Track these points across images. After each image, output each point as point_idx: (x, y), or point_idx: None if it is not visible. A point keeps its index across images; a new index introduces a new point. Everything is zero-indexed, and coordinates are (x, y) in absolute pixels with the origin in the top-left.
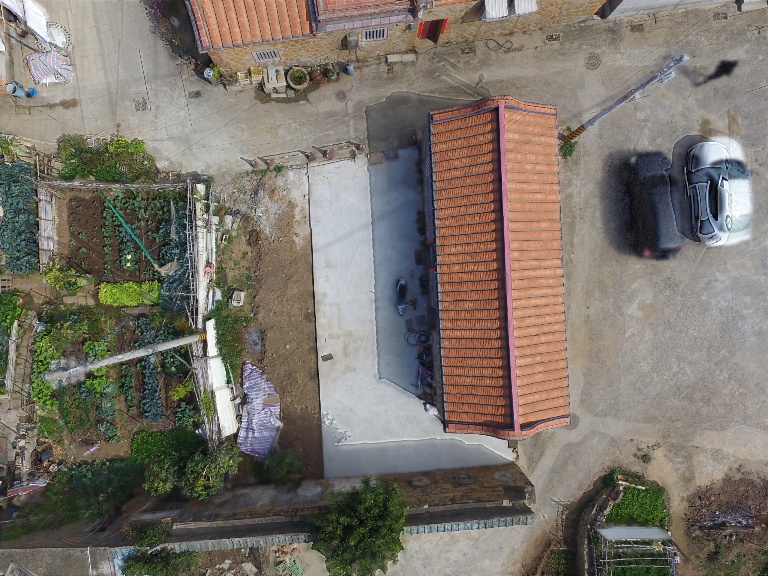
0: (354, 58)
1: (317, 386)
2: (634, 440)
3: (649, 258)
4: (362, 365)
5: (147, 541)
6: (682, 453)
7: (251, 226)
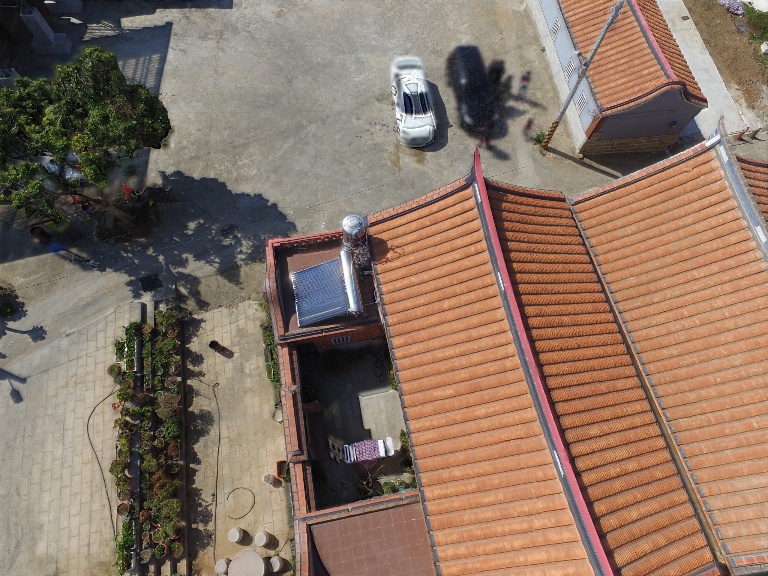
0: None
1: (685, 5)
2: None
3: (458, 68)
4: None
5: None
6: None
7: None
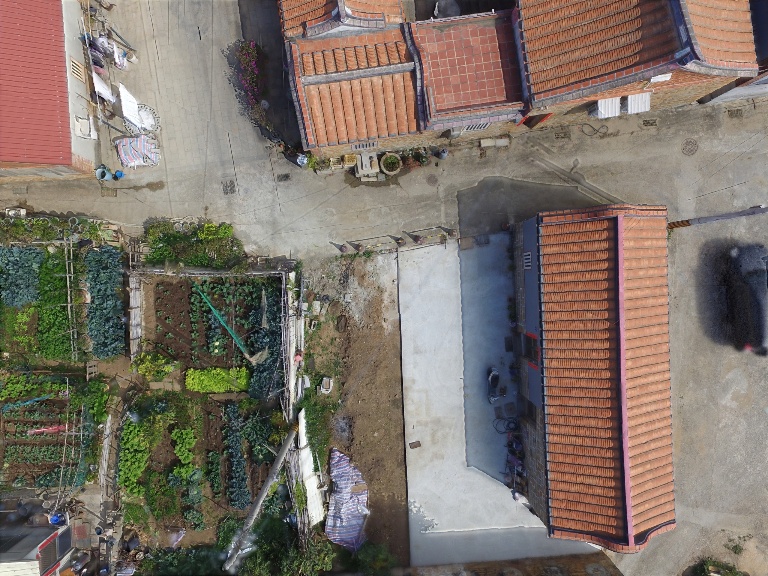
0: (447, 142)
1: (404, 473)
2: (725, 530)
3: (744, 348)
4: (450, 452)
5: None
6: None
7: (339, 311)
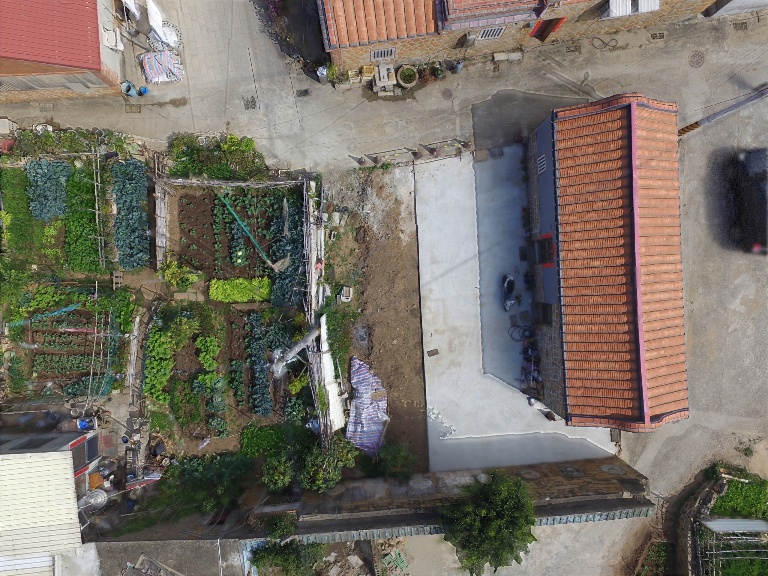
0: (461, 56)
1: (422, 381)
2: (736, 434)
3: (752, 254)
4: (467, 360)
5: (279, 533)
6: None
7: (358, 223)
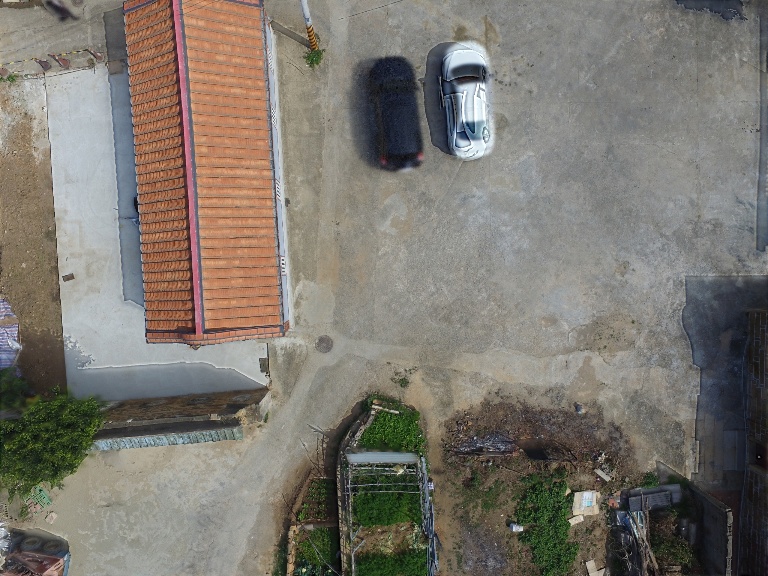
0: None
1: (60, 308)
2: (391, 364)
3: (402, 172)
4: (106, 286)
5: None
6: (440, 377)
7: None
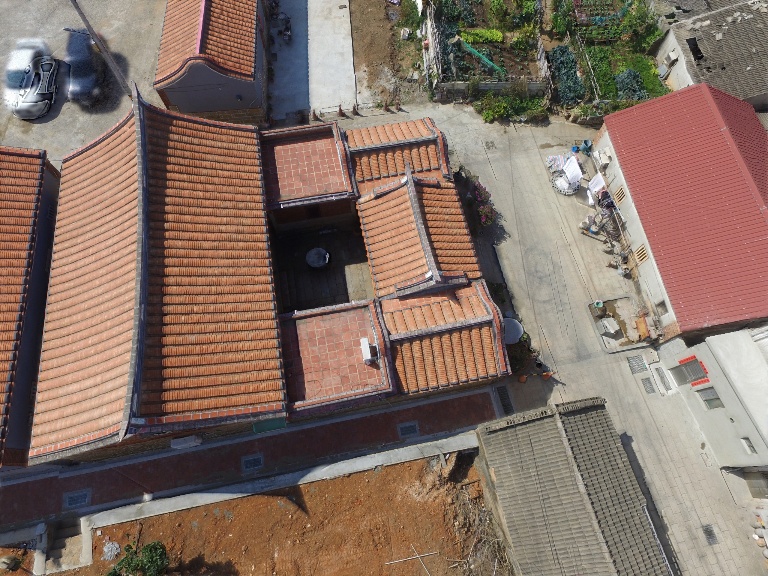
0: None
1: None
2: None
3: None
4: (318, 4)
5: None
6: None
7: None
